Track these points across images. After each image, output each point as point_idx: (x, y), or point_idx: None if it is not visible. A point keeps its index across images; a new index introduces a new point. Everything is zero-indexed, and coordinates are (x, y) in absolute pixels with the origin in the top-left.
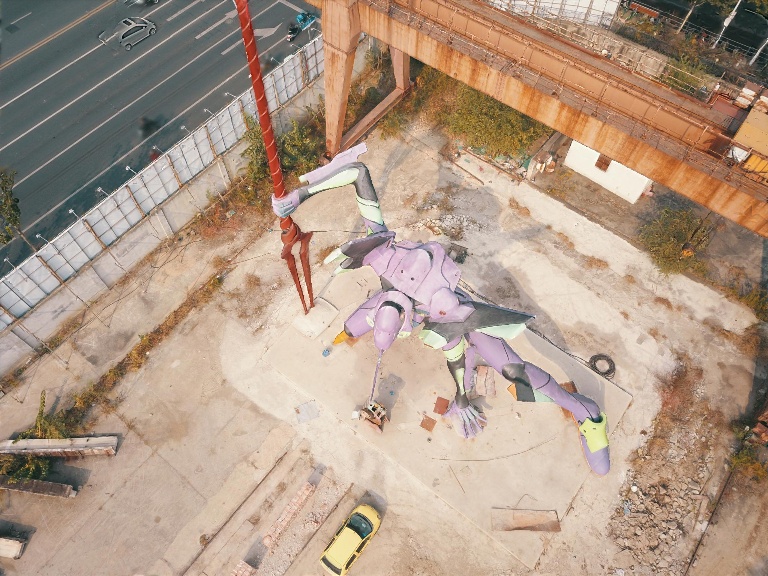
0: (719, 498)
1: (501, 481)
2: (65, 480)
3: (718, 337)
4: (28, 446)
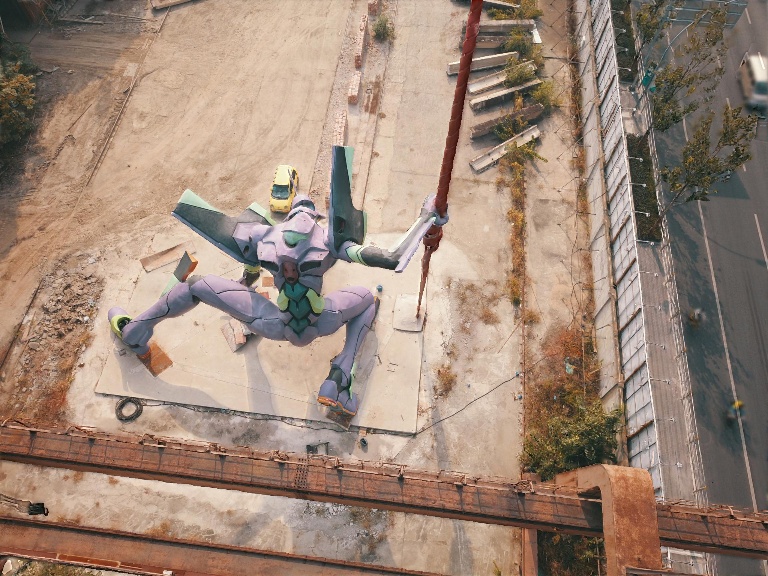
0: (12, 345)
1: (195, 272)
2: (485, 140)
3: (4, 510)
4: (523, 139)
